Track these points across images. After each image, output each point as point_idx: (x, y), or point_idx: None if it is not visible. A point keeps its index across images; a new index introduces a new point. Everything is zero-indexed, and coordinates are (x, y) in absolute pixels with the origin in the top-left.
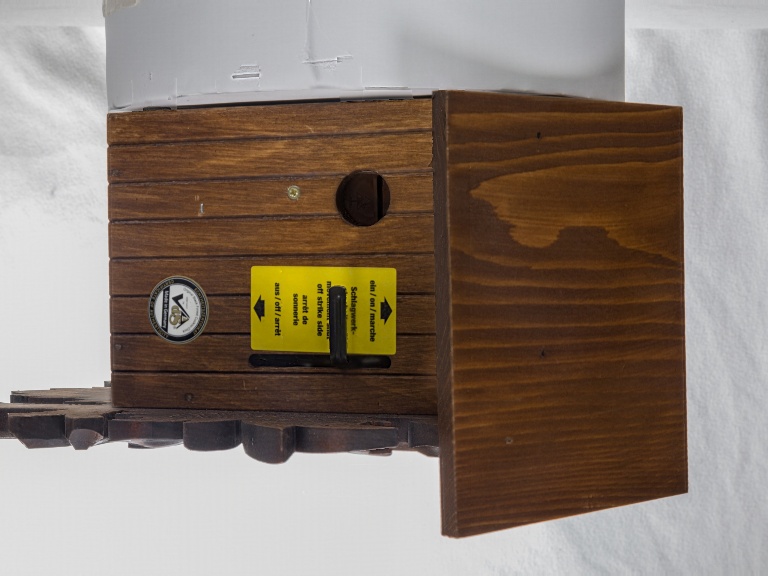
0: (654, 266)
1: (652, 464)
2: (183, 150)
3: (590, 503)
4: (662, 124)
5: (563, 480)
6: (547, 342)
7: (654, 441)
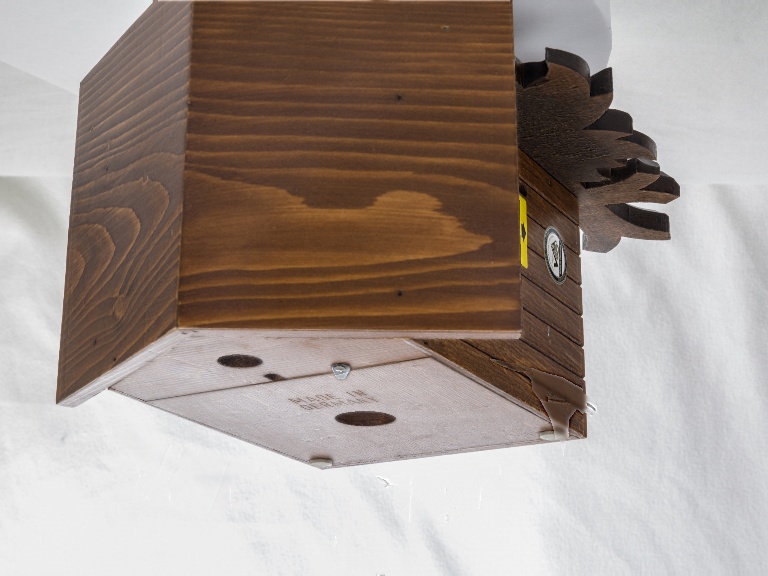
0: (234, 169)
1: None
2: None
3: None
4: (212, 309)
5: None
6: (393, 107)
7: (245, 9)
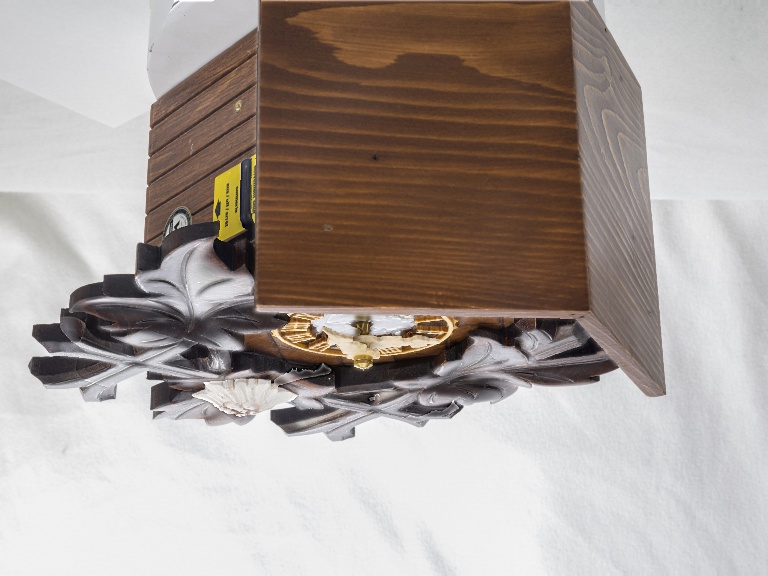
0: (530, 94)
1: (531, 275)
2: (185, 108)
3: (439, 300)
4: None
5: (401, 273)
6: (380, 148)
7: (534, 254)
